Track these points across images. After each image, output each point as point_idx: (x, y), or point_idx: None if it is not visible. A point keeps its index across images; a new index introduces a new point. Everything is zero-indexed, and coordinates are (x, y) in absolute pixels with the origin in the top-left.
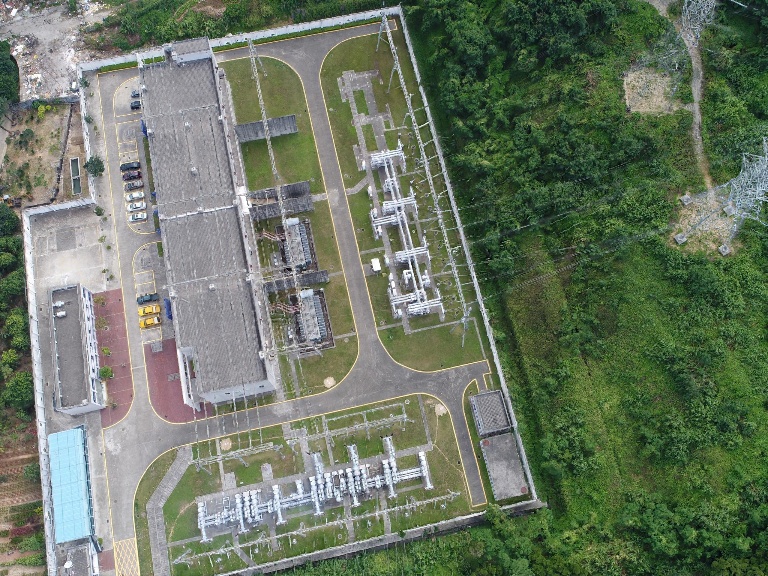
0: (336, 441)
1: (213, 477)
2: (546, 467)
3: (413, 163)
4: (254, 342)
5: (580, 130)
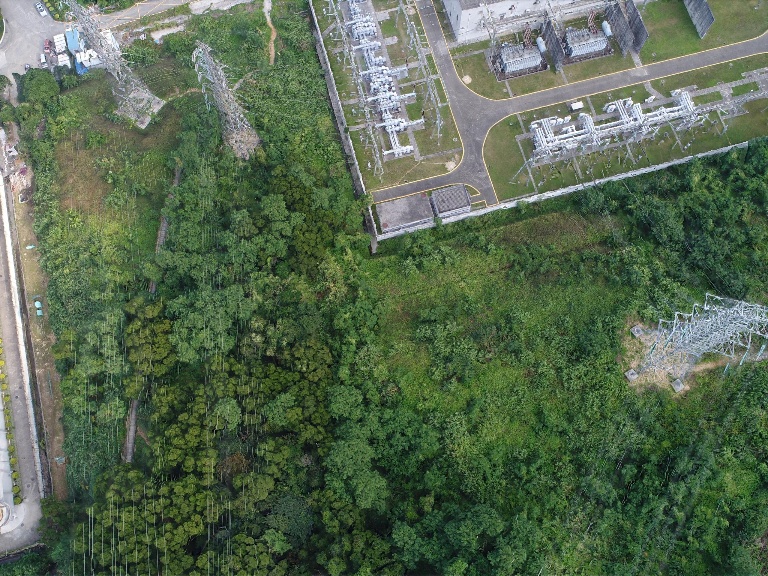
0: (419, 87)
1: (386, 5)
2: (405, 236)
3: (688, 136)
4: (493, 1)
5: (747, 249)
